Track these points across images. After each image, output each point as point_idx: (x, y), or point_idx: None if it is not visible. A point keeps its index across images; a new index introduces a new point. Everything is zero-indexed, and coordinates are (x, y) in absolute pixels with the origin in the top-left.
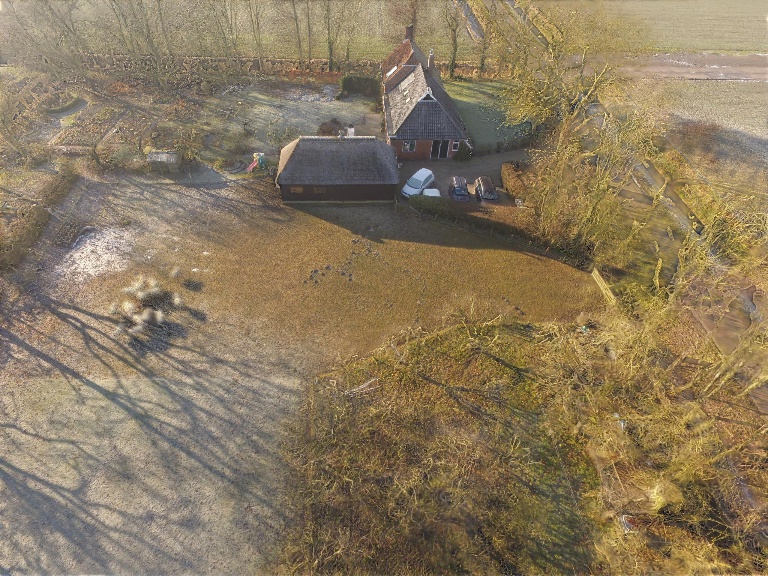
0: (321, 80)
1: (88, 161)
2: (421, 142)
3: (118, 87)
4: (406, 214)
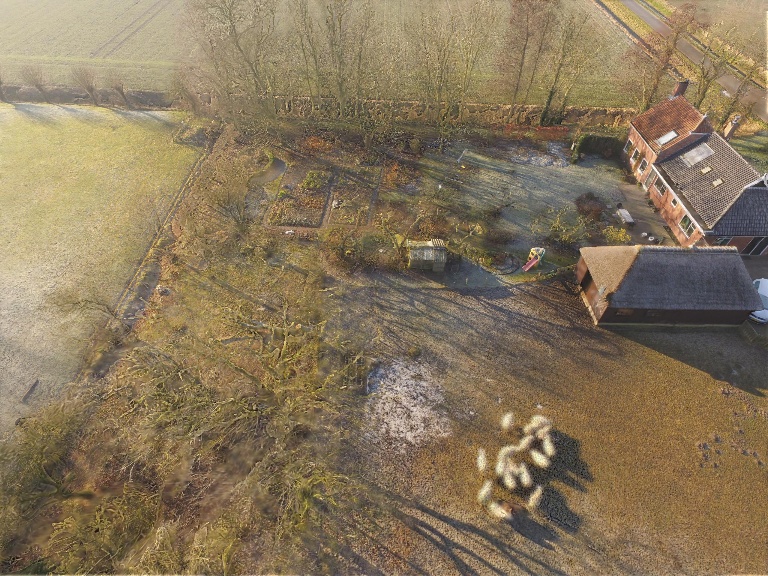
0: (541, 136)
1: (324, 251)
2: (740, 238)
3: (308, 141)
4: (766, 347)
